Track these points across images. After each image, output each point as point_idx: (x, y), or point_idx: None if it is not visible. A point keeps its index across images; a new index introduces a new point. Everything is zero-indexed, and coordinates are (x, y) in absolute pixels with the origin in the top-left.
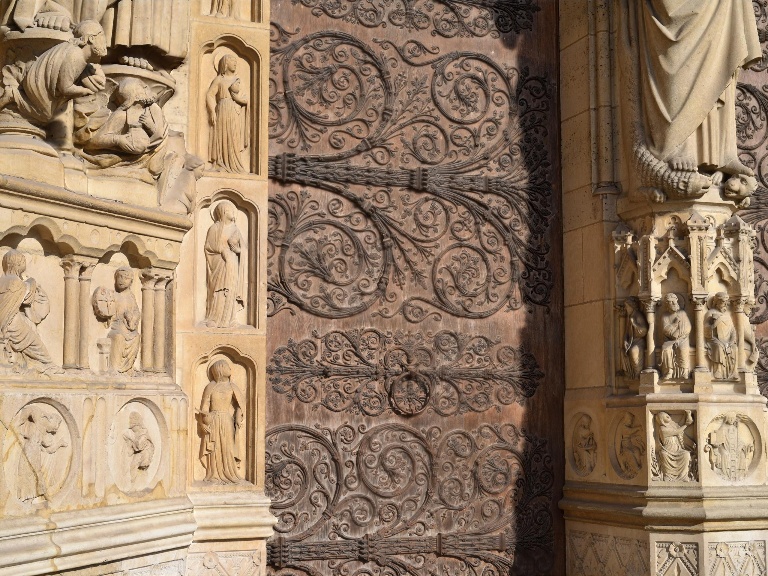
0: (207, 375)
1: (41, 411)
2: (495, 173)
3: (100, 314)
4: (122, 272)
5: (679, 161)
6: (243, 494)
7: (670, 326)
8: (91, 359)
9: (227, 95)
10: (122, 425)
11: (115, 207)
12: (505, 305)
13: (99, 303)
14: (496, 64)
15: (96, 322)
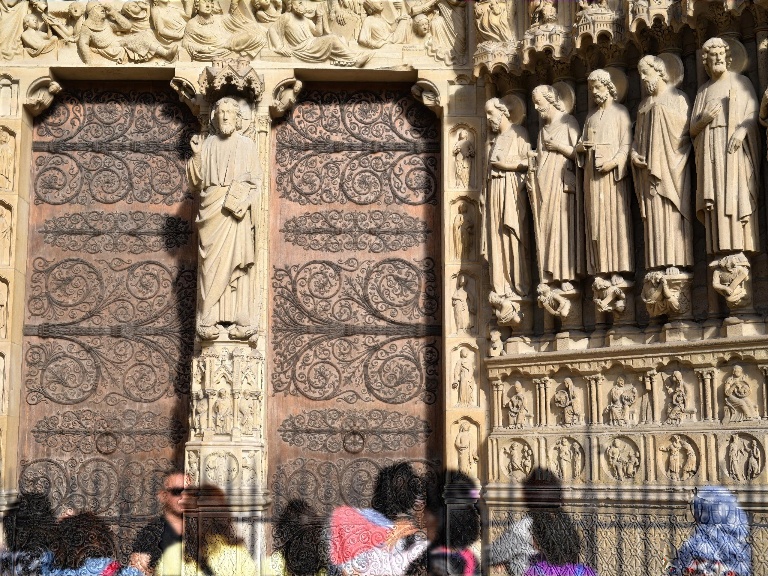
0: None
1: None
2: (162, 324)
3: None
4: None
5: (204, 321)
6: None
7: (198, 407)
8: None
9: None
10: None
11: None
12: (165, 395)
13: None
14: (164, 266)
15: None
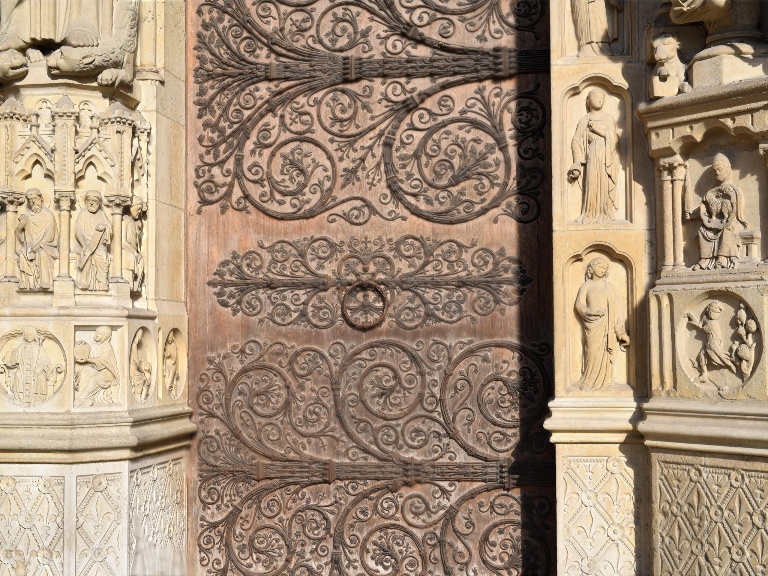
0: None
1: None
2: None
3: None
4: None
5: None
6: None
7: None
8: None
9: None
10: None
11: None
12: None
13: None
14: None
15: None
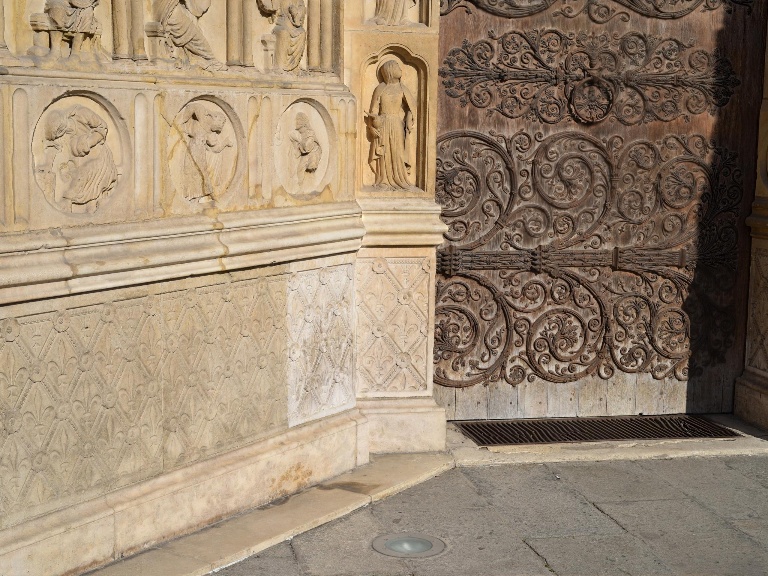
0: (377, 76)
1: (205, 109)
2: None
3: (264, 8)
4: None
5: None
6: (413, 200)
7: None
8: (256, 56)
9: None
10: (288, 126)
11: None
12: (701, 4)
13: None
14: None
15: (260, 17)
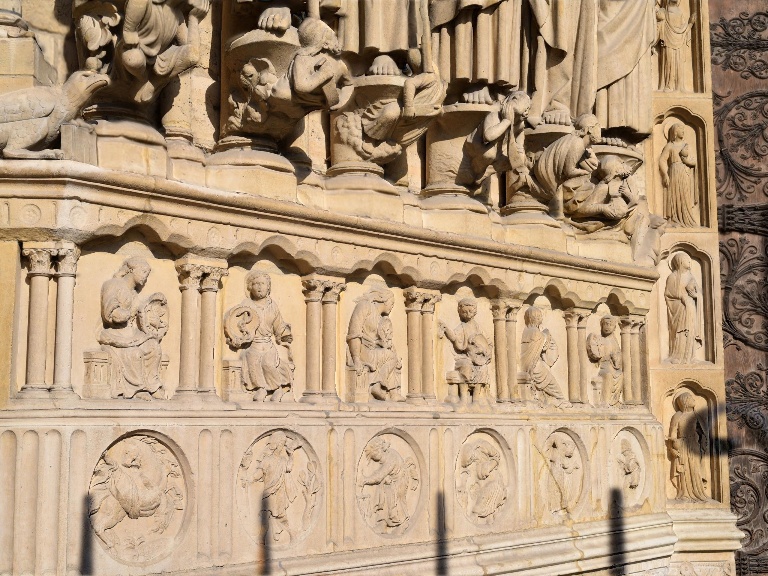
0: (673, 406)
1: (561, 439)
2: None
3: (593, 356)
4: (607, 320)
5: None
6: (712, 511)
7: None
8: (588, 394)
9: (678, 159)
10: (616, 450)
11: (604, 266)
12: None
13: (592, 347)
14: None
15: (589, 363)
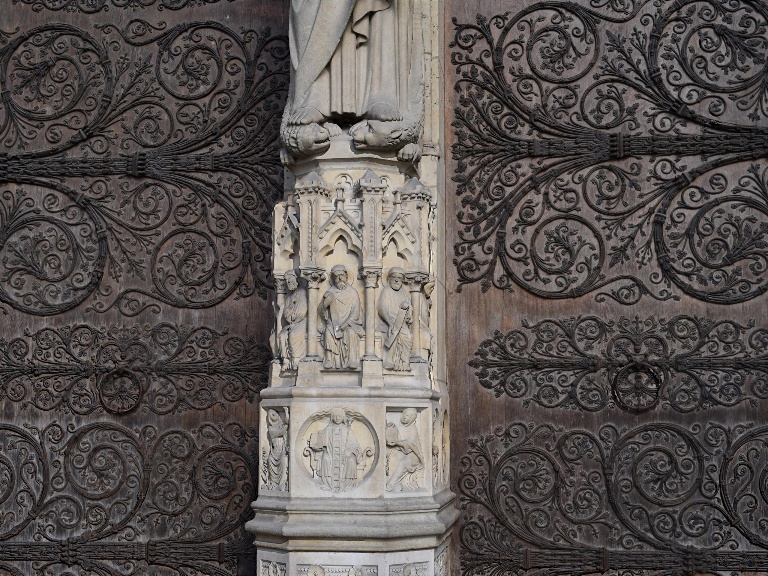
0: None
1: None
2: (227, 149)
3: None
4: None
5: (296, 114)
6: None
7: (286, 308)
8: None
9: None
10: None
11: None
12: (235, 292)
13: None
14: (229, 29)
15: None
